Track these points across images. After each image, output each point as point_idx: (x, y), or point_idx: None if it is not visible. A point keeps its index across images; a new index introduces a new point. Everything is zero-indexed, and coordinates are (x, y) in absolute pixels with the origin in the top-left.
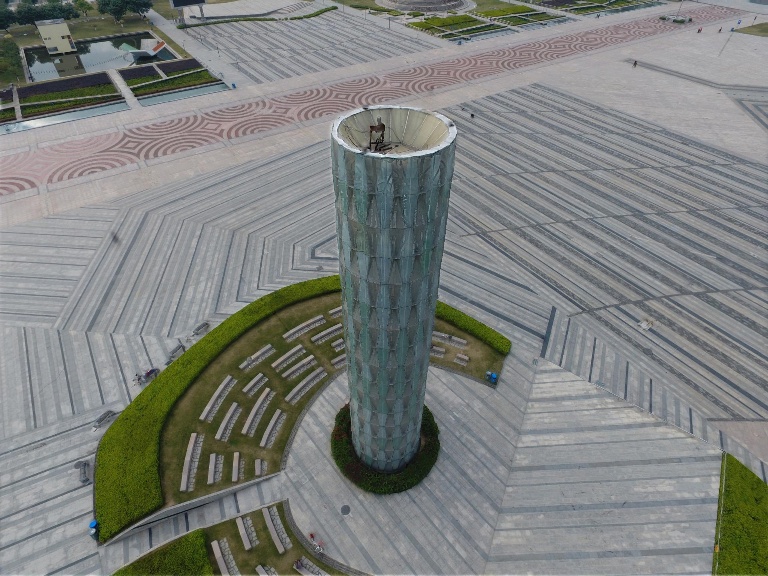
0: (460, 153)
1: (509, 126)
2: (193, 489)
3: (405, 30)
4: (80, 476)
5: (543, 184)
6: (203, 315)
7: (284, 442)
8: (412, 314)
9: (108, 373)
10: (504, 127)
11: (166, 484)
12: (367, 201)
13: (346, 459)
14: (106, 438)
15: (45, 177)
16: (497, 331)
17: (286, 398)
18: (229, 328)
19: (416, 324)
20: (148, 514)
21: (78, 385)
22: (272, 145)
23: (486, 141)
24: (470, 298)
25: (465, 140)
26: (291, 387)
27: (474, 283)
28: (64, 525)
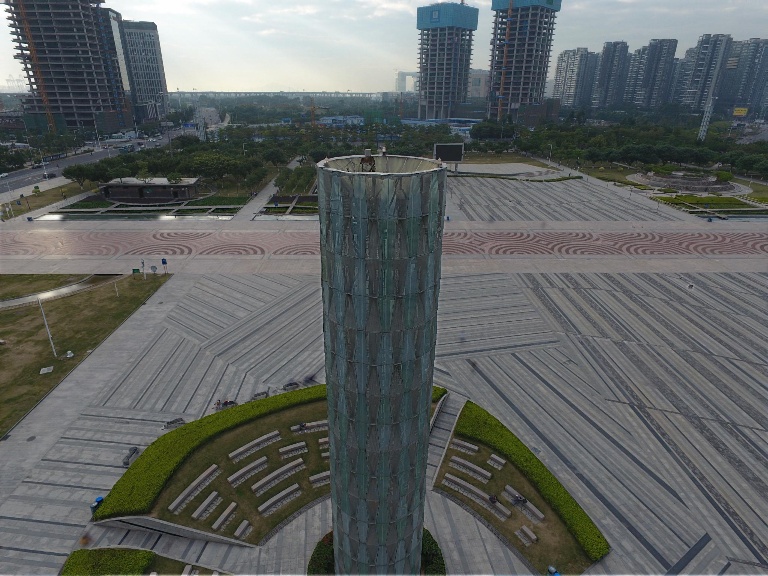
0: (653, 318)
1: (740, 307)
2: (178, 513)
3: (647, 201)
4: (125, 457)
5: (764, 380)
6: (300, 376)
7: (281, 519)
8: (373, 378)
9: (204, 391)
10: (732, 306)
11: (164, 496)
12: (325, 220)
13: (319, 569)
14: (162, 437)
15: (274, 250)
16: (597, 525)
17: (311, 477)
18: (308, 392)
19: (378, 395)
20: (133, 513)
21: (180, 391)
22: (451, 266)
23: (697, 314)
24: (580, 470)
25: (667, 307)
26: (323, 469)
27: (595, 456)
28: (88, 490)
